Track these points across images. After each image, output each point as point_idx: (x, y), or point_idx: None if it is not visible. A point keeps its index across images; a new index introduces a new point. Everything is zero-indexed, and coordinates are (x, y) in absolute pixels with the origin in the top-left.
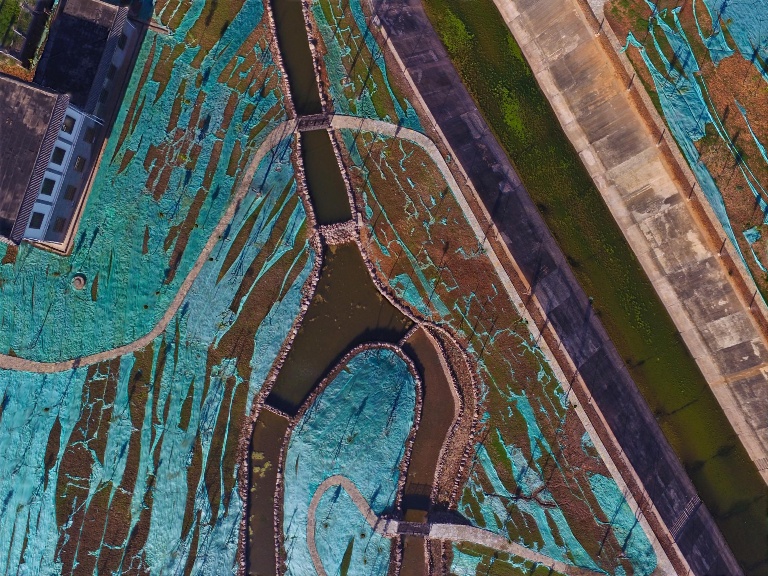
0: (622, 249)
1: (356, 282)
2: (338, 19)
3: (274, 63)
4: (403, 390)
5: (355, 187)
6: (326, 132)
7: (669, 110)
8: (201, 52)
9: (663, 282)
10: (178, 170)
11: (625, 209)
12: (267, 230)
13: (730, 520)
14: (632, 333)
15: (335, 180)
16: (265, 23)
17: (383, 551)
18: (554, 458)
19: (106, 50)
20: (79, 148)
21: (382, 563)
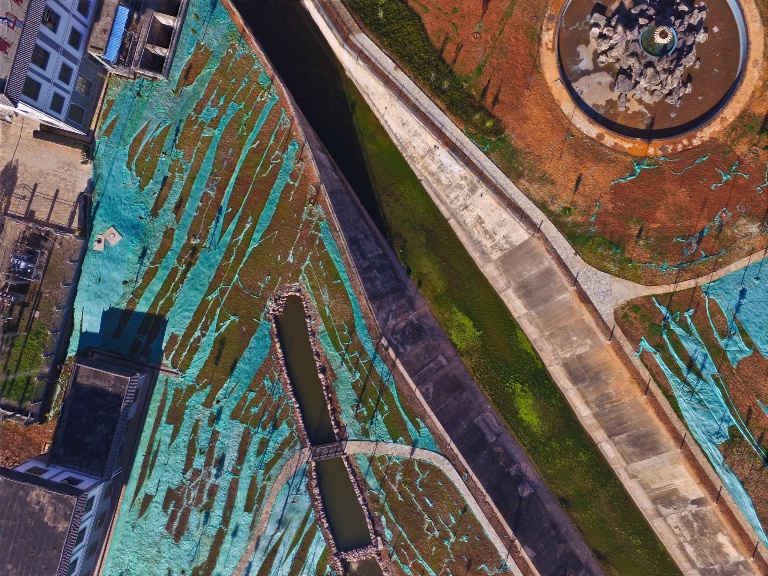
0: (649, 539)
1: None
2: (345, 345)
3: (285, 393)
4: None
5: (373, 511)
6: (340, 459)
7: (689, 414)
8: (212, 392)
9: (695, 574)
10: (196, 511)
11: (650, 502)
12: (288, 563)
13: None
14: None
15: (352, 504)
16: (273, 354)
17: None
18: None
19: (120, 419)
20: (99, 510)
21: None
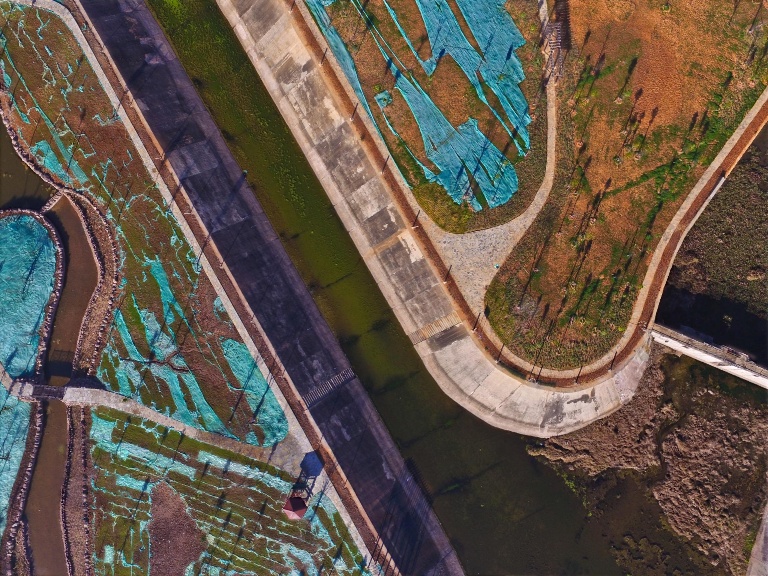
0: (276, 123)
1: (5, 152)
2: None
3: None
4: (42, 255)
5: None
6: None
7: None
8: None
9: (313, 154)
10: None
11: (275, 81)
12: None
13: (385, 396)
14: (286, 206)
15: None
16: None
17: (21, 415)
18: (187, 323)
19: None
20: None
21: (20, 427)
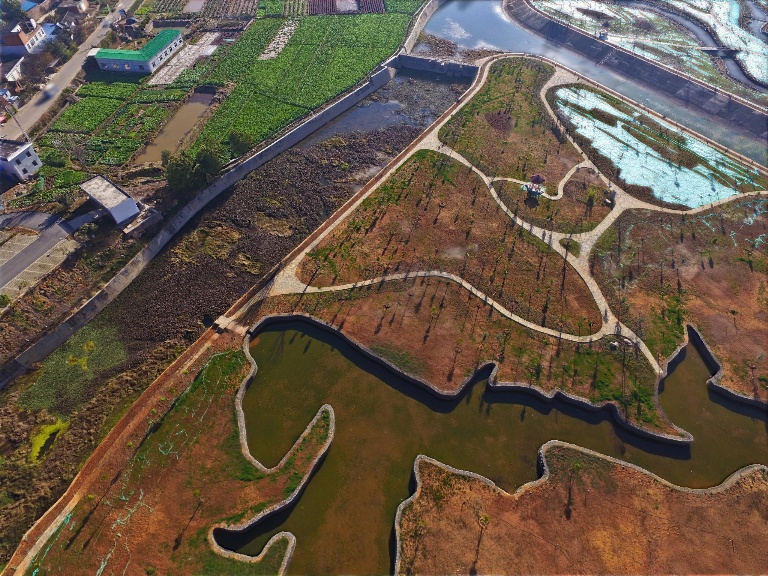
0: None
1: None
2: None
3: None
4: None
5: None
6: None
7: None
8: None
9: None
10: None
11: None
12: None
13: None
14: None
15: None
16: None
17: None
18: None
19: None
20: None
21: None
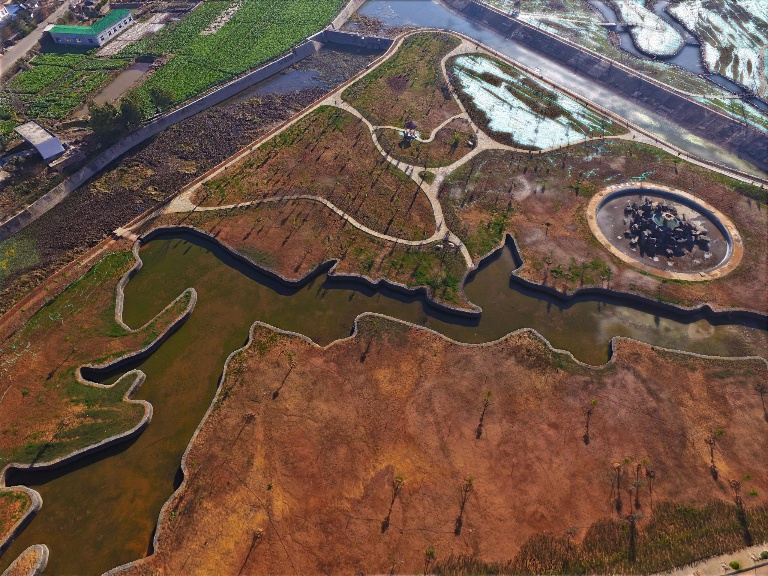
0: None
1: None
2: None
3: None
4: None
5: None
6: None
7: None
8: None
9: None
10: None
11: None
12: None
13: None
14: (552, 69)
15: None
16: None
17: None
18: None
19: None
20: None
21: None
